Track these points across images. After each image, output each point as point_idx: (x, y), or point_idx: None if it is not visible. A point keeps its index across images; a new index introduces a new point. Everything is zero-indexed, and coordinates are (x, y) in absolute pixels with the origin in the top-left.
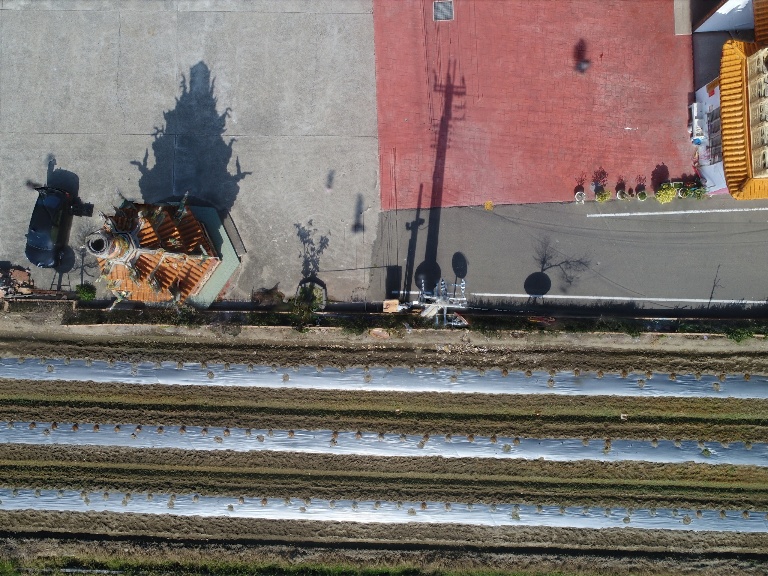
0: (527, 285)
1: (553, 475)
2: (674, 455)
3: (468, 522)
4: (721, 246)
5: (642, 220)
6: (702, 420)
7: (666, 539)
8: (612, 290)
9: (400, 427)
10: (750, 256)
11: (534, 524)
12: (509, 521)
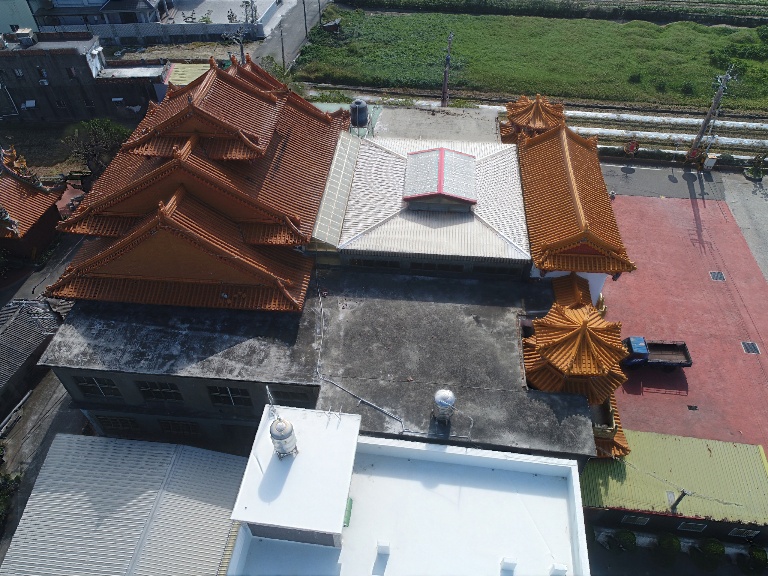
0: None
1: (602, 125)
2: None
3: None
4: None
5: None
6: None
7: None
8: None
9: (684, 142)
10: None
11: None
12: None
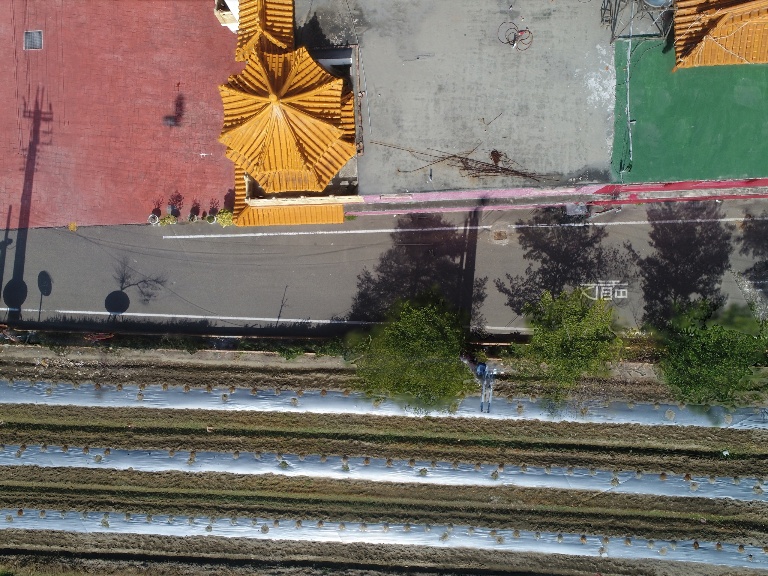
0: (107, 303)
1: (142, 485)
2: (253, 467)
3: (62, 529)
4: (288, 267)
5: (215, 242)
6: (283, 433)
7: (246, 547)
8: (186, 309)
9: None
10: (315, 277)
11: (123, 531)
12: (99, 528)
